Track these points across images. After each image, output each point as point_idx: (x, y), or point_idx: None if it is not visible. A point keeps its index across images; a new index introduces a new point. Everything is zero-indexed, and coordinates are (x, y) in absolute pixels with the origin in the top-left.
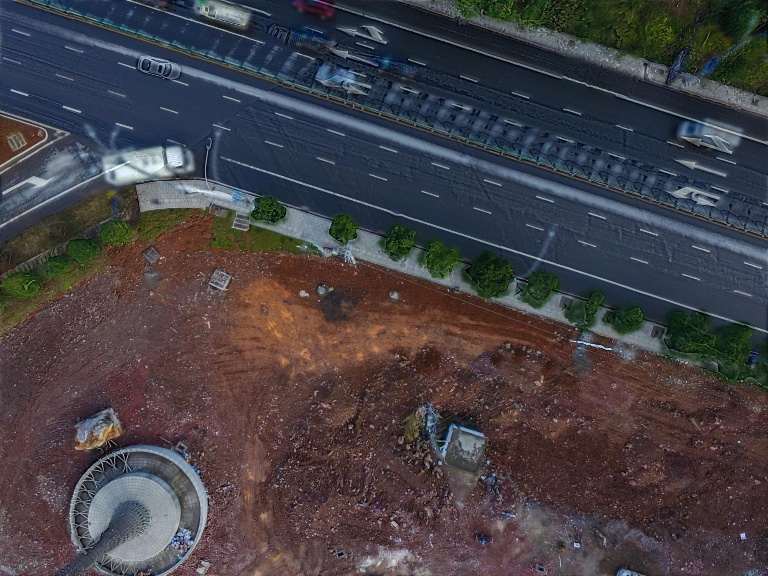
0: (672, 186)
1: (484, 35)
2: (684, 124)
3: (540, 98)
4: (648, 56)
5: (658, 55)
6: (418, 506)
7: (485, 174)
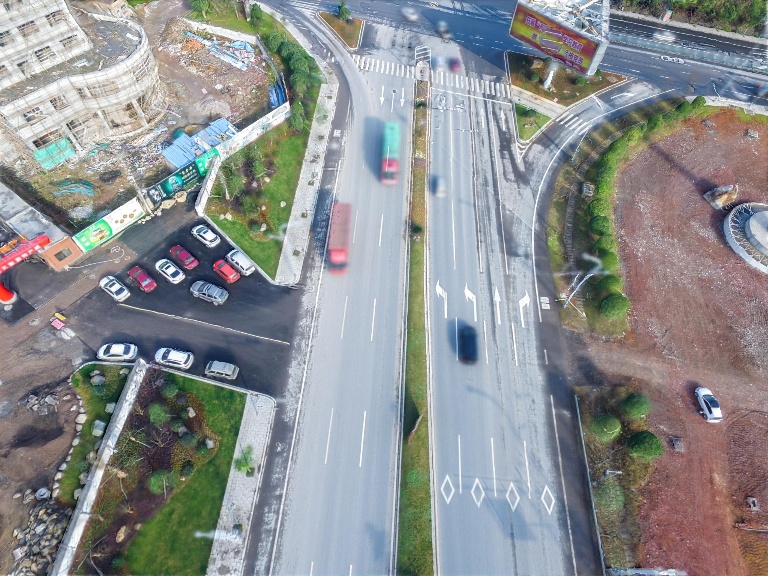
0: None
1: None
2: None
3: None
4: None
5: None
6: None
7: None
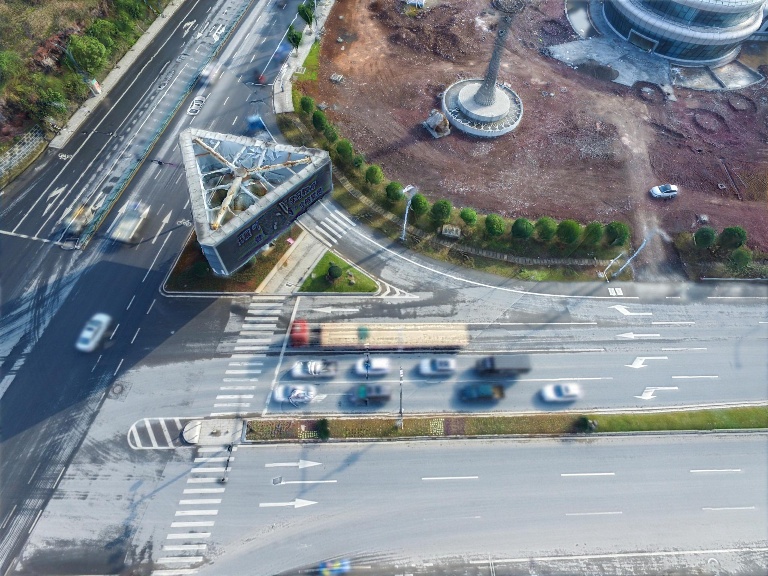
0: None
1: None
2: None
3: None
4: None
5: None
6: (451, 13)
7: None
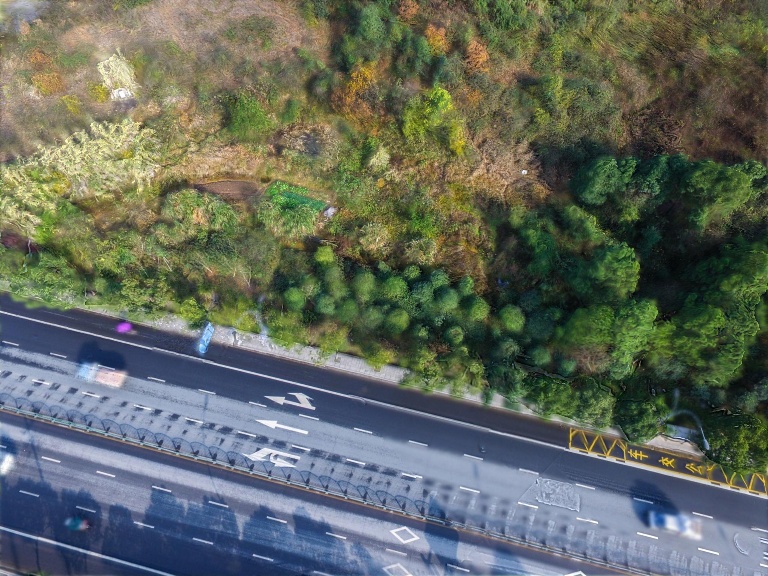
0: (250, 448)
1: (87, 316)
2: (268, 384)
3: (127, 368)
4: (237, 325)
5: (246, 324)
6: None
7: (45, 450)
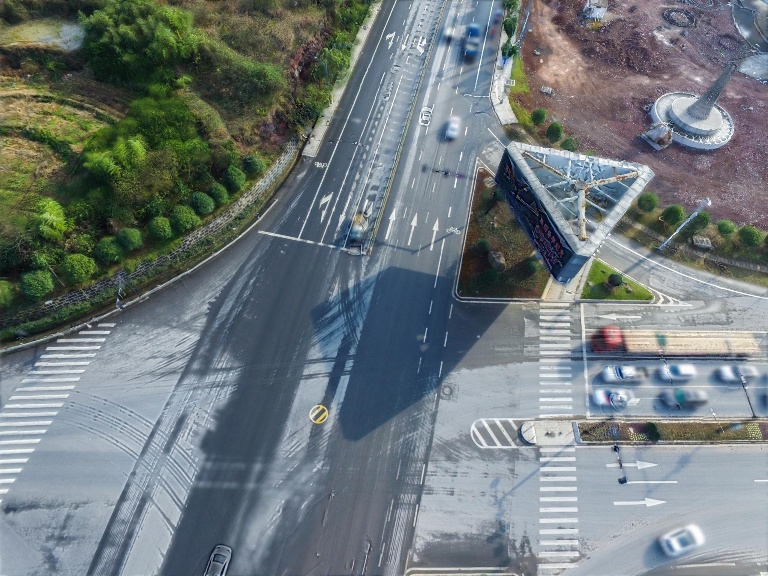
0: None
1: (386, 2)
2: None
3: None
4: None
5: None
6: None
7: (458, 3)
